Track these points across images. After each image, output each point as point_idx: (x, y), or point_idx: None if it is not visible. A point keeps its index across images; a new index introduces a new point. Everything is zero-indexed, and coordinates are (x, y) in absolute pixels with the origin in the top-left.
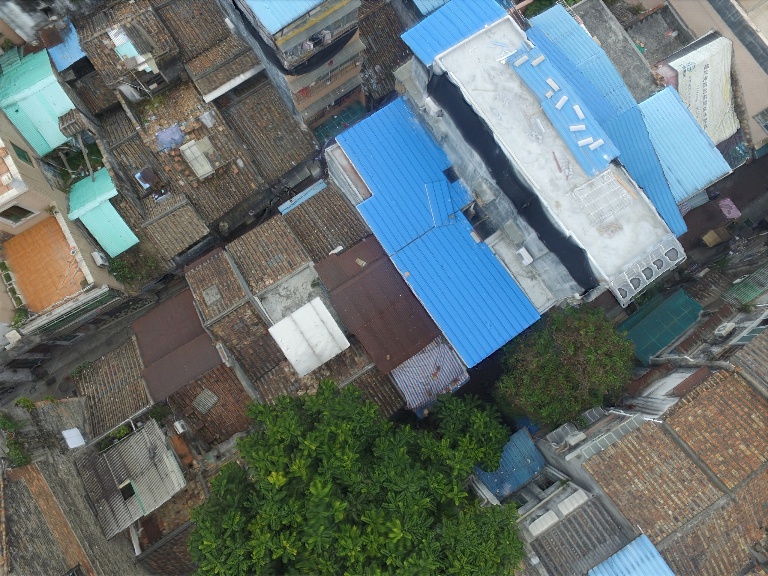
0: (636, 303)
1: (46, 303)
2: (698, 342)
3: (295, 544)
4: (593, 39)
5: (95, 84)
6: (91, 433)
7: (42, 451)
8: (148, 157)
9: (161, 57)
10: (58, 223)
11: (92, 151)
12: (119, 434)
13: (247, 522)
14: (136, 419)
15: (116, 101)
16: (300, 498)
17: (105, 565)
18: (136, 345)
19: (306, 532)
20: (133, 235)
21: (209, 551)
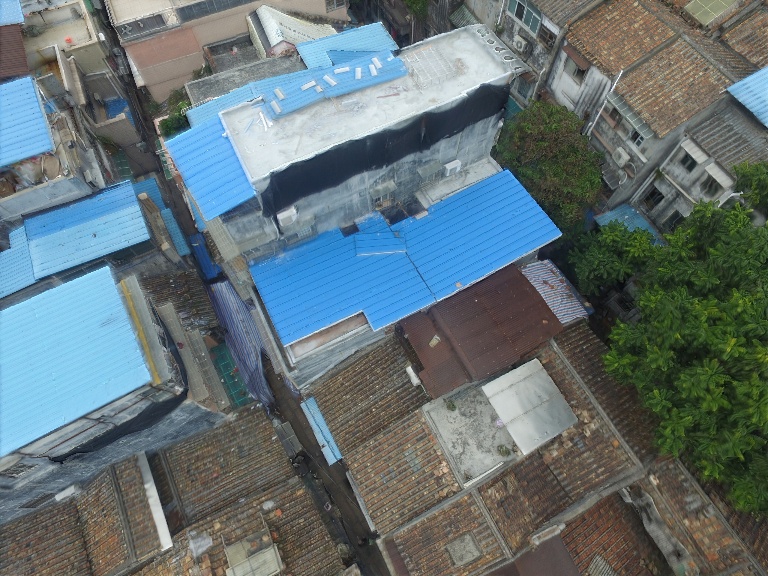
0: None
1: None
2: None
3: None
4: None
5: None
6: None
7: None
8: None
9: None
10: None
11: None
12: None
13: None
14: None
15: None
16: None
17: None
18: None
19: None
20: None
21: None
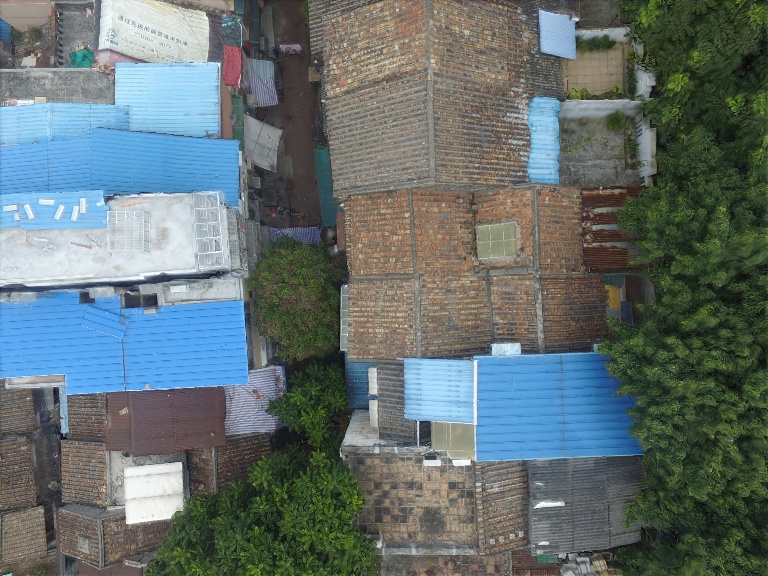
0: None
1: None
2: None
3: None
4: (36, 101)
5: None
6: None
7: None
8: None
9: None
10: None
11: None
12: None
13: None
14: None
15: None
16: None
17: None
18: None
19: None
20: None
21: None
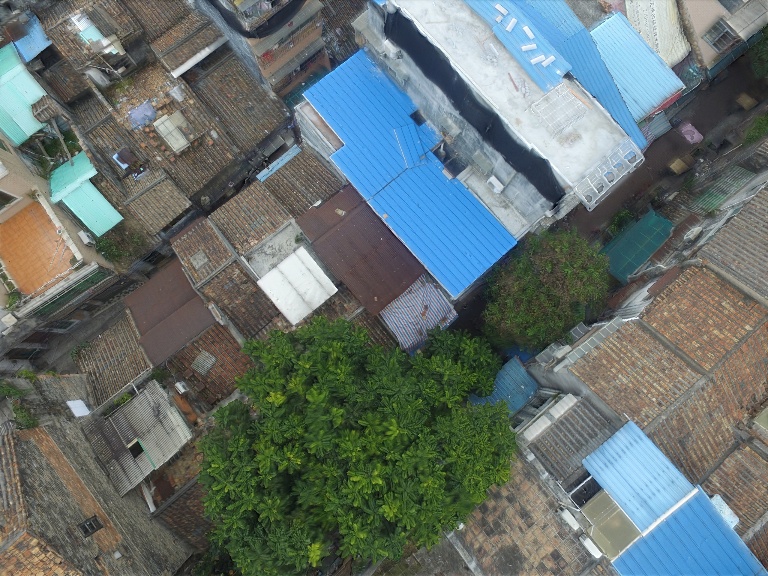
0: (613, 236)
1: (38, 285)
2: (670, 251)
3: (298, 455)
4: None
5: (64, 72)
6: (95, 405)
7: (48, 417)
8: (124, 138)
9: (126, 38)
10: (42, 207)
11: (68, 137)
12: (123, 400)
13: (251, 443)
14: (138, 386)
15: (87, 87)
16: (299, 415)
17: (121, 518)
18: (131, 317)
19: (307, 439)
20: (117, 213)
21: (217, 473)
